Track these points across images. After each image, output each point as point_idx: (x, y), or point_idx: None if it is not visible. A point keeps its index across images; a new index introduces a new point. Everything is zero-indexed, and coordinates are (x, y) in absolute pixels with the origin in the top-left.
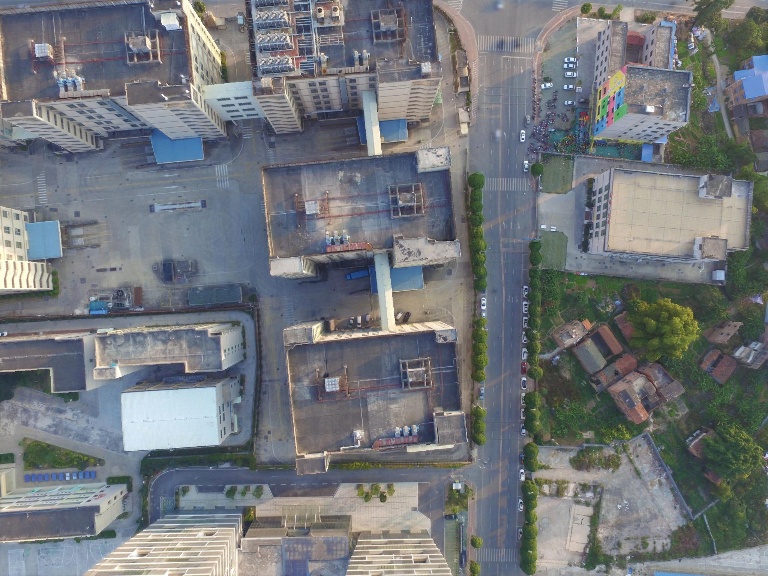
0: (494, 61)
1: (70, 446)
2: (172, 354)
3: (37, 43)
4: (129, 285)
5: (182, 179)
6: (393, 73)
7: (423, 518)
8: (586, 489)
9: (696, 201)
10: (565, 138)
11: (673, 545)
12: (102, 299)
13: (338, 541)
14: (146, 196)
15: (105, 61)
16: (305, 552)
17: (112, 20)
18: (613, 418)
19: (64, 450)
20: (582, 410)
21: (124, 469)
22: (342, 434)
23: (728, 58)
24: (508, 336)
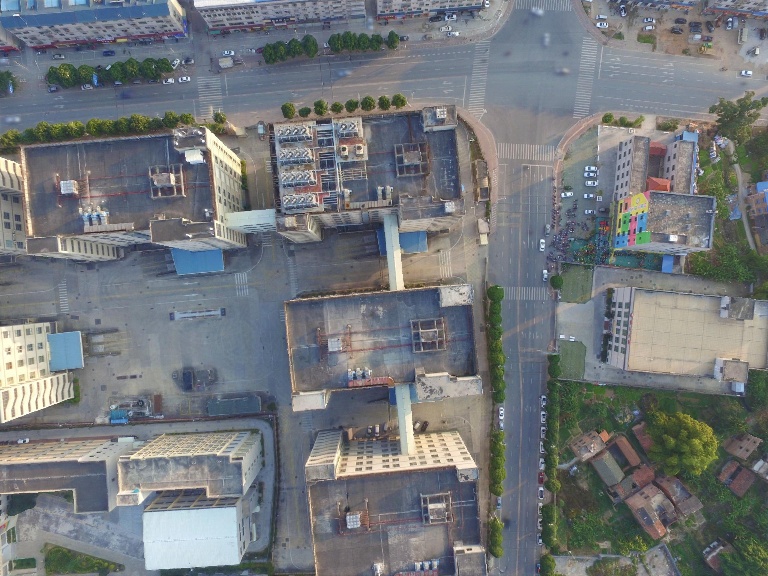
0: (514, 169)
1: (90, 551)
2: (194, 478)
3: (62, 176)
4: (149, 393)
5: (202, 287)
6: (416, 210)
7: None
8: None
9: (717, 321)
10: (585, 247)
11: None
12: (122, 406)
13: None
14: (166, 304)
15: (129, 194)
16: None
17: (136, 153)
18: (630, 530)
19: (85, 555)
20: (599, 522)
21: (144, 574)
22: (363, 567)
23: (750, 165)
24: (526, 446)
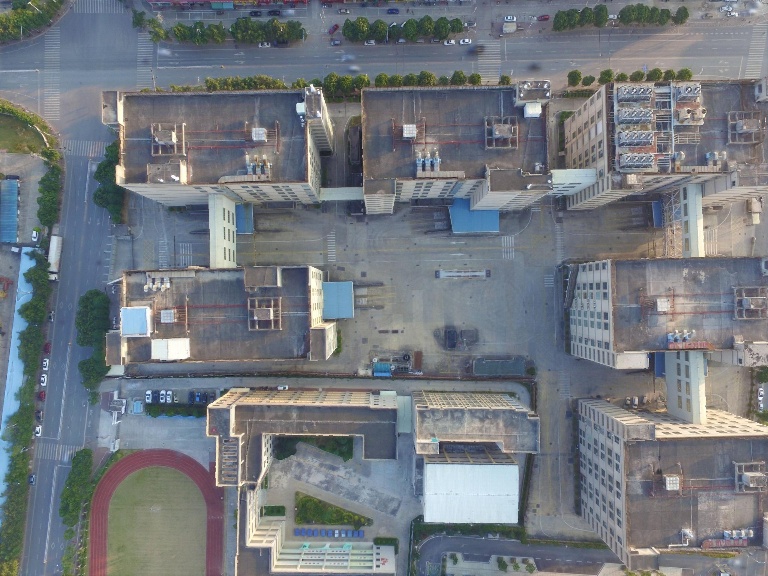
0: None
1: (340, 503)
2: (488, 432)
3: (397, 121)
4: (410, 348)
5: (469, 247)
6: (753, 177)
7: None
8: None
9: None
10: None
11: None
12: (382, 360)
13: None
14: (432, 262)
15: (462, 143)
16: None
17: (471, 103)
18: None
19: (335, 507)
20: None
21: (391, 530)
22: (670, 531)
23: None
24: None
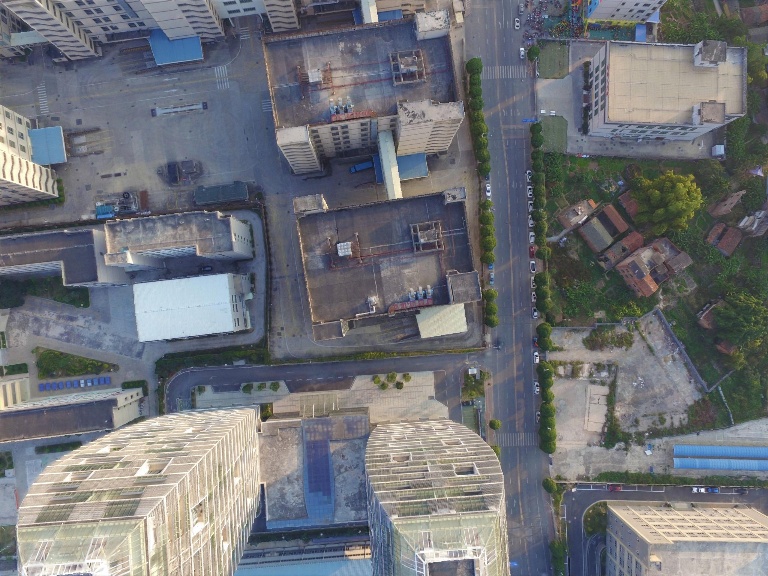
0: None
1: (83, 353)
2: (182, 238)
3: None
4: (134, 189)
5: (182, 82)
6: None
7: (440, 406)
8: (601, 368)
9: (692, 70)
10: (559, 24)
11: (690, 419)
12: (108, 205)
13: (358, 420)
14: (147, 101)
15: None
16: (326, 432)
17: None
18: (623, 294)
19: (77, 357)
20: (592, 288)
21: (139, 373)
22: (357, 301)
23: None
24: (514, 221)
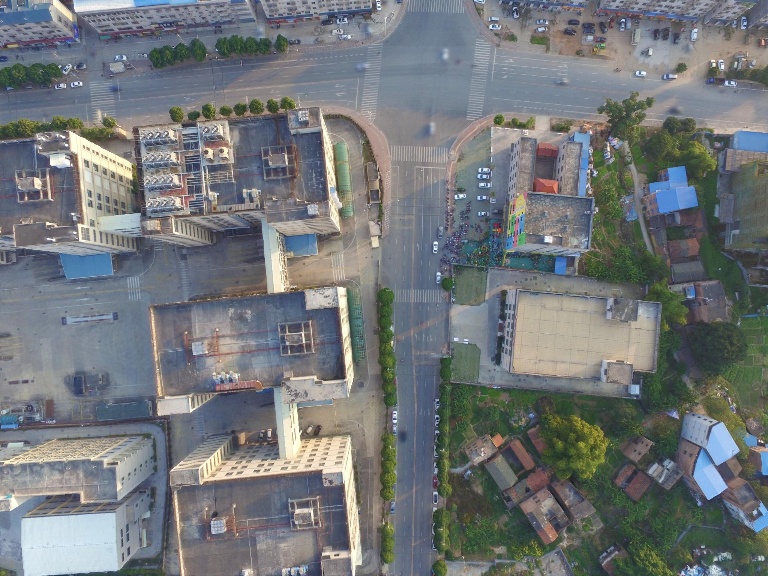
0: (407, 171)
1: None
2: (68, 484)
3: None
4: (41, 397)
5: (94, 291)
6: (281, 213)
7: None
8: None
9: (603, 322)
10: (478, 249)
11: None
12: (14, 411)
13: None
14: (58, 308)
15: None
16: None
17: (4, 158)
18: (524, 535)
19: None
20: (493, 527)
21: None
22: (231, 573)
23: (646, 166)
24: (420, 449)
